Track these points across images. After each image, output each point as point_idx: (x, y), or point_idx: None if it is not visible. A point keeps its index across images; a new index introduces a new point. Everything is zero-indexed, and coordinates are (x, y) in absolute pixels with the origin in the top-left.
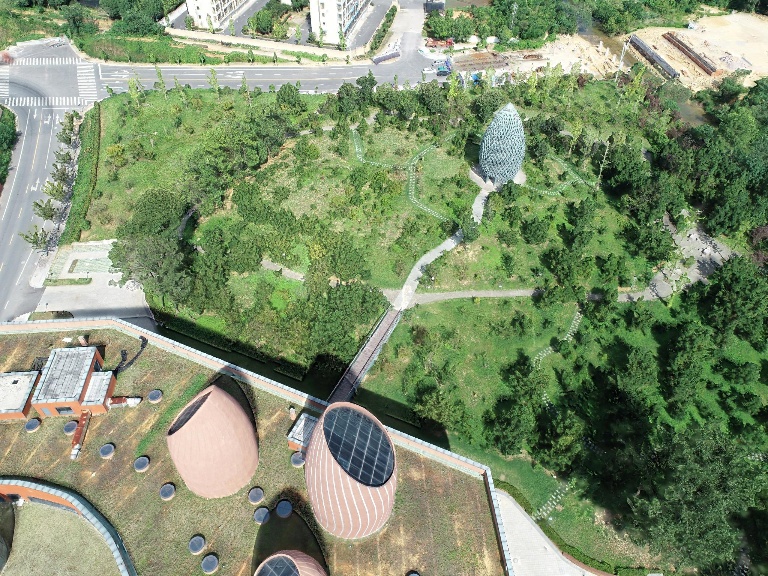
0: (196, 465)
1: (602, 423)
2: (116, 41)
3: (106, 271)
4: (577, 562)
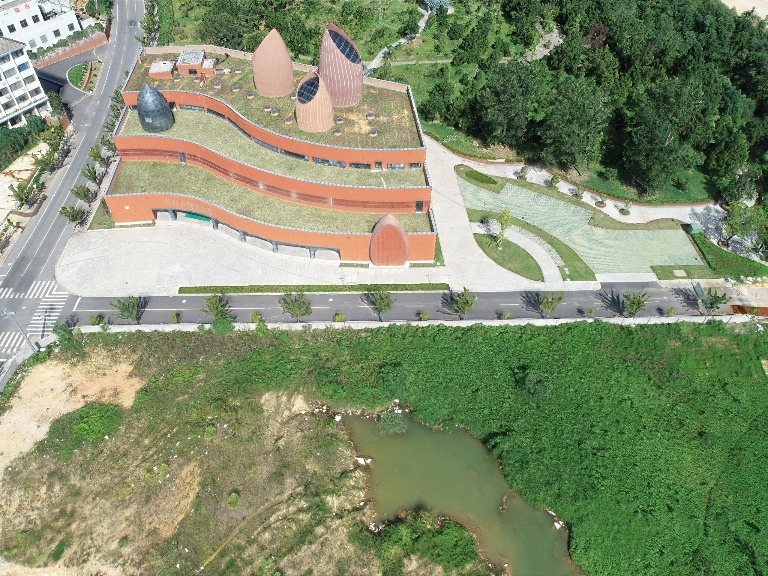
0: (267, 66)
1: None
2: None
3: None
4: (460, 155)
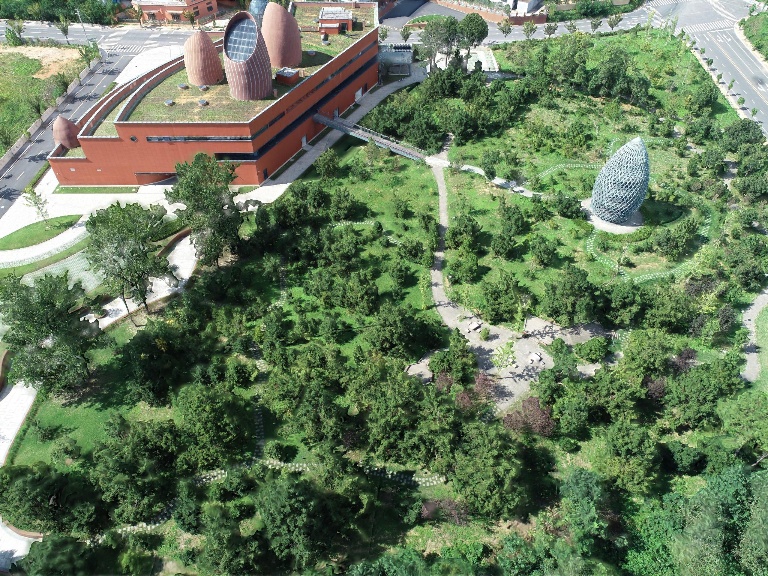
0: None
1: None
2: (765, 21)
3: None
4: None
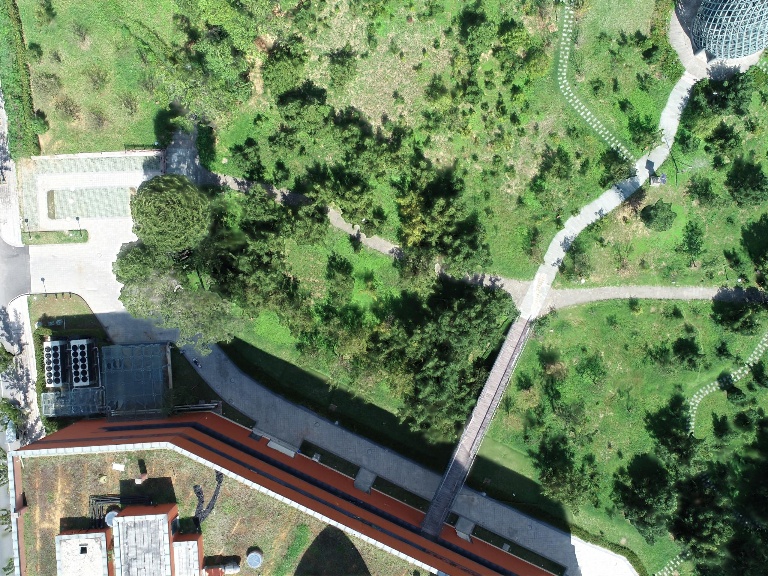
0: None
1: (749, 484)
2: None
3: (103, 216)
4: None
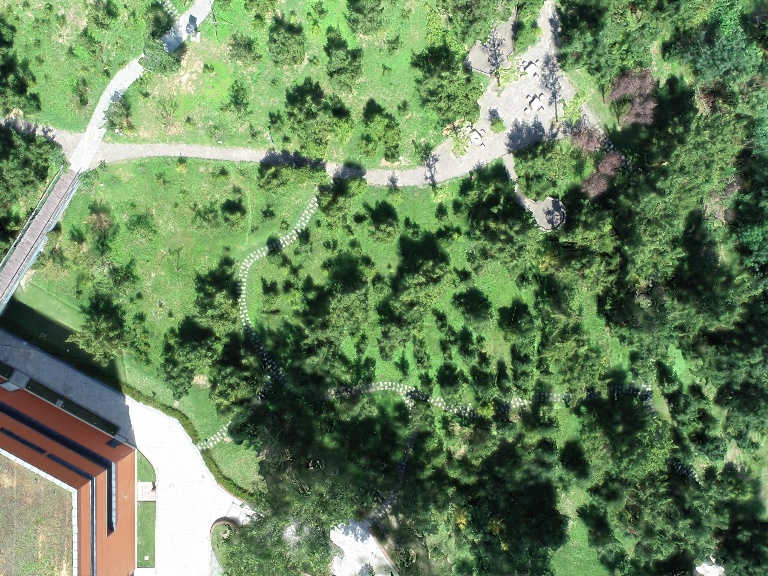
0: None
1: None
2: None
3: None
4: (228, 493)
